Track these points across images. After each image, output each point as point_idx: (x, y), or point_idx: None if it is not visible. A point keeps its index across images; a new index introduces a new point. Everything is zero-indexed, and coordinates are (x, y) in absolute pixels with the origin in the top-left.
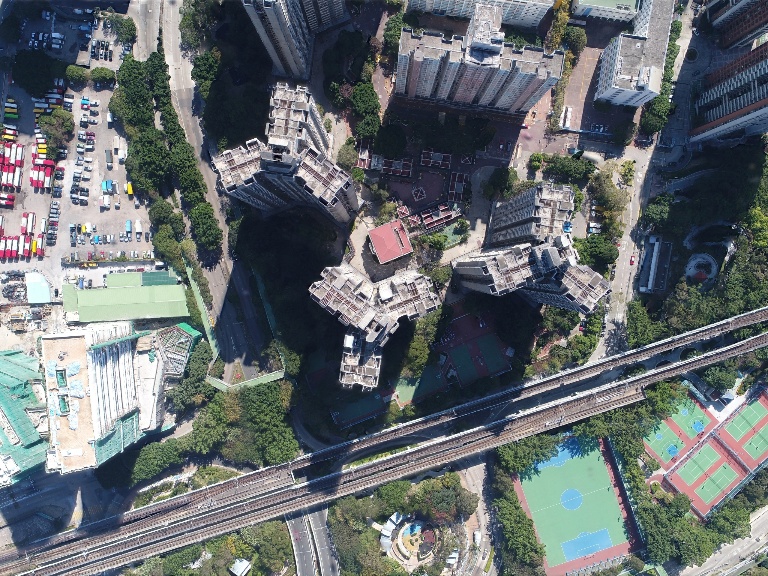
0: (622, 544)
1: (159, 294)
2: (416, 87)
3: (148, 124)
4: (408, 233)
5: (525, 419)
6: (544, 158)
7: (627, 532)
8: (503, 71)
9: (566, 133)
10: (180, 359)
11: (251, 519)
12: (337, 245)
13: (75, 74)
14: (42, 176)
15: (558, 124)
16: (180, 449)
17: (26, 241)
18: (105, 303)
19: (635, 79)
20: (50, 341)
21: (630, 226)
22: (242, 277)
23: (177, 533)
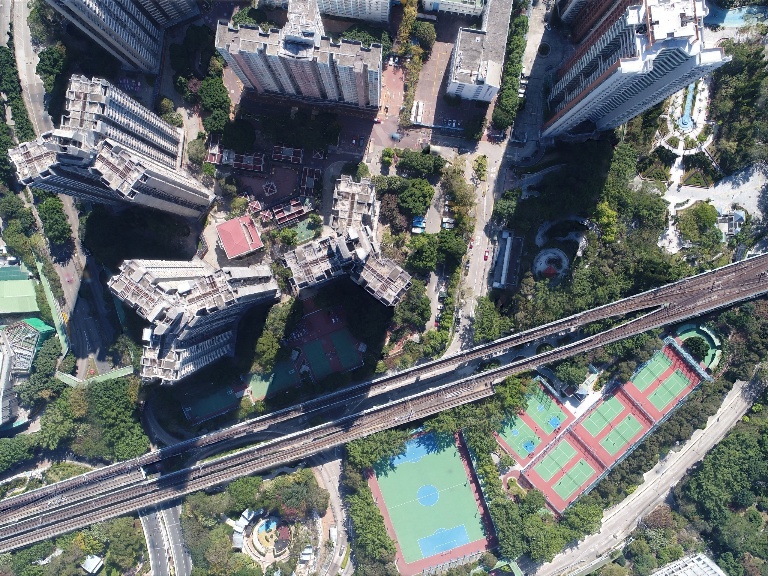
0: (479, 540)
1: (8, 289)
2: (258, 81)
3: None
4: (262, 228)
5: (374, 415)
6: (396, 153)
7: (484, 528)
8: (322, 64)
9: (419, 128)
10: (27, 354)
11: (102, 515)
12: (191, 240)
13: None
14: None
15: (409, 119)
16: (27, 445)
17: None
18: None
19: (475, 73)
20: None
21: (484, 221)
22: (95, 272)
23: (27, 529)
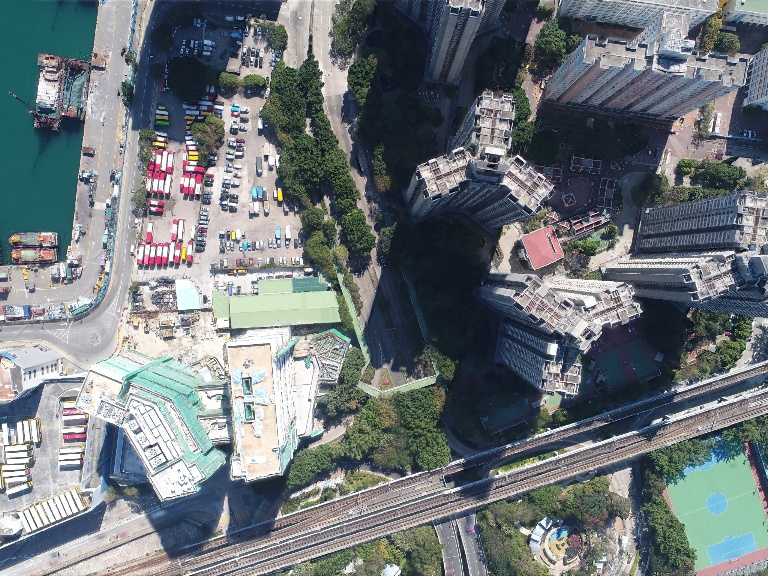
0: (767, 548)
1: (311, 300)
2: (575, 94)
3: (301, 131)
4: None
5: (677, 424)
6: (693, 164)
7: None
8: (685, 78)
9: (714, 139)
10: (334, 365)
11: (402, 524)
12: (485, 251)
13: (228, 81)
14: (193, 183)
15: (708, 130)
16: (334, 455)
17: (176, 248)
18: (257, 309)
19: None
20: (235, 349)
21: None
22: (390, 283)
23: (328, 538)
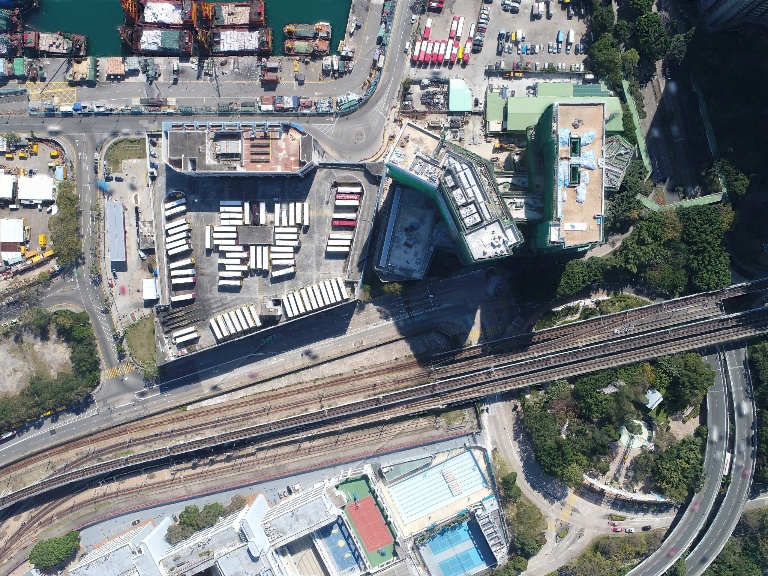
0: None
1: None
2: None
3: None
4: None
5: None
6: None
7: None
8: None
9: None
10: (617, 171)
11: (670, 348)
12: None
13: None
14: None
15: None
16: (609, 266)
17: (455, 45)
18: (537, 111)
19: None
20: (566, 107)
21: None
22: (674, 97)
23: (590, 356)
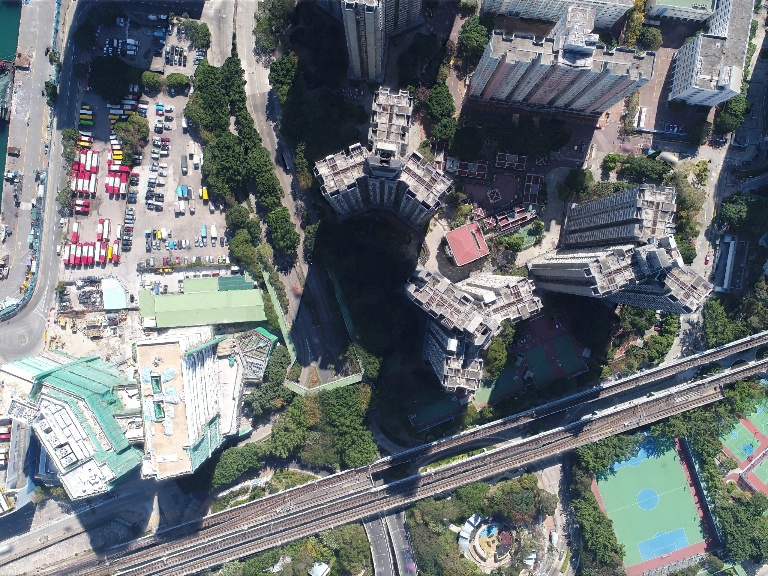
0: (698, 543)
1: (236, 299)
2: (495, 89)
3: (224, 129)
4: (483, 235)
5: (604, 420)
6: (618, 159)
7: (703, 531)
8: (593, 73)
9: (640, 133)
10: (259, 363)
11: (330, 522)
12: (412, 248)
13: (151, 80)
14: (118, 182)
15: (633, 124)
16: (260, 453)
17: (102, 247)
18: (183, 308)
19: (715, 79)
20: (145, 347)
21: (704, 226)
22: (317, 281)
23: (256, 537)
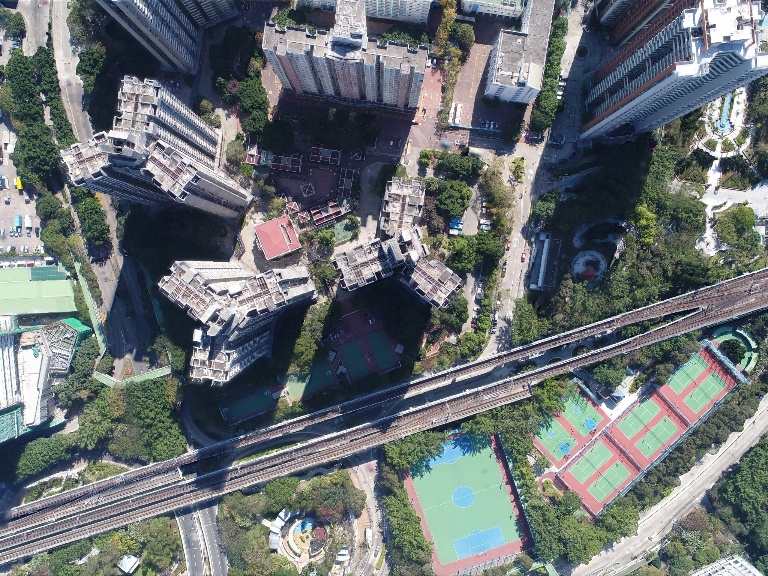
0: (514, 542)
1: (46, 289)
2: (298, 83)
3: (35, 119)
4: (299, 229)
5: (412, 416)
6: (434, 154)
7: (519, 530)
8: (368, 66)
9: (457, 130)
10: (65, 354)
11: (138, 515)
12: (228, 241)
13: None
14: None
15: (447, 120)
16: (65, 444)
17: None
18: None
19: (516, 75)
20: None
21: (521, 223)
22: (132, 273)
23: (64, 529)
